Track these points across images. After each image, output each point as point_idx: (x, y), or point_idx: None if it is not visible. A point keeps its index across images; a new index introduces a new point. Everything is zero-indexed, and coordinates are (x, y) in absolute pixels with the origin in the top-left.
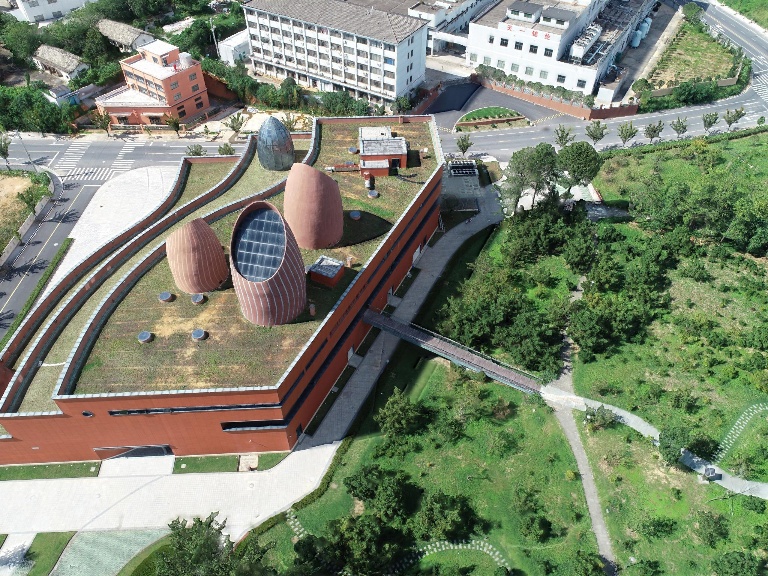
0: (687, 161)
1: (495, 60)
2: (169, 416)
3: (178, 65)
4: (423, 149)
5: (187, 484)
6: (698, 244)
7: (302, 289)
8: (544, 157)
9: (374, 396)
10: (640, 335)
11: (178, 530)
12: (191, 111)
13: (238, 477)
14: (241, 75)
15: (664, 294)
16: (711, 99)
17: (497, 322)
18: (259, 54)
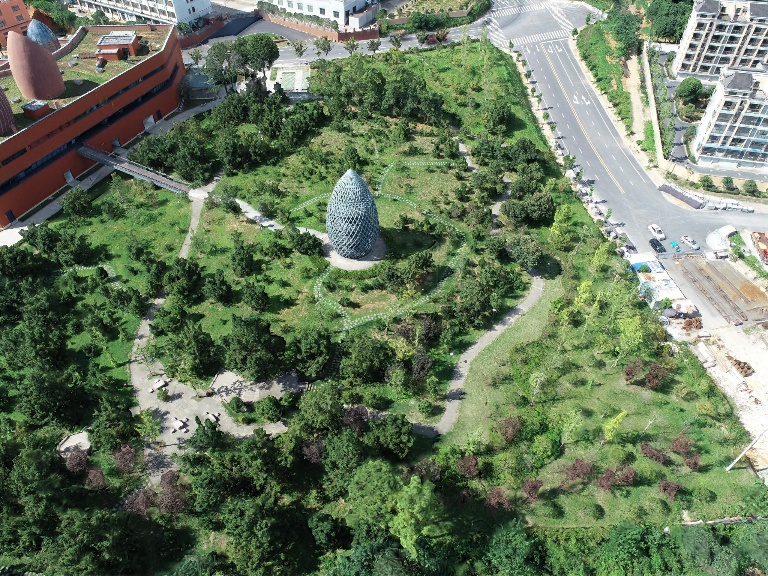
0: (384, 63)
1: None
2: None
3: None
4: (156, 45)
5: None
6: (349, 109)
7: (2, 112)
8: (239, 48)
9: None
10: (273, 159)
11: None
12: None
13: None
14: (61, 9)
15: (312, 140)
16: (443, 27)
17: (166, 149)
18: None
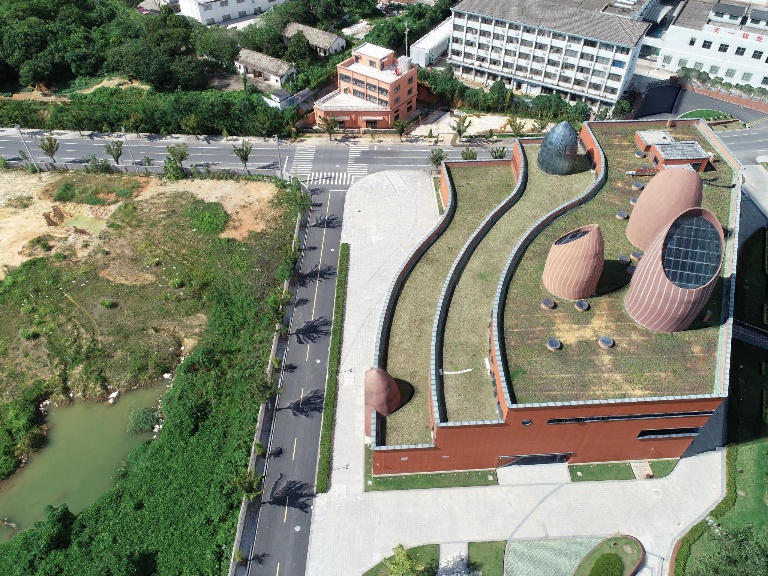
0: None
1: (692, 62)
2: (600, 424)
3: (394, 69)
4: (707, 153)
5: (592, 492)
6: None
7: None
8: None
9: (736, 402)
10: None
11: (731, 541)
12: (403, 115)
13: (639, 485)
14: (449, 78)
15: None
16: None
17: None
18: (458, 57)
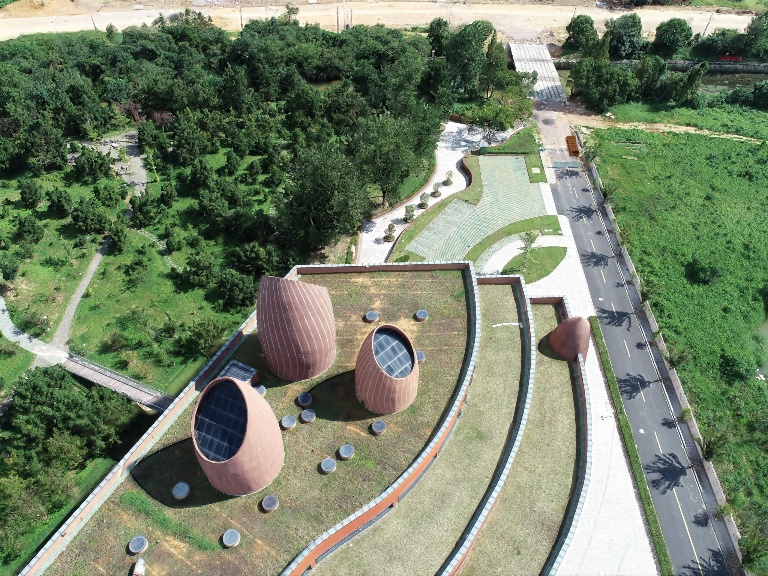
0: None
1: None
2: None
3: None
4: None
5: None
6: None
7: None
8: None
9: None
10: None
11: None
12: None
13: None
14: None
15: None
16: None
17: None
18: None
